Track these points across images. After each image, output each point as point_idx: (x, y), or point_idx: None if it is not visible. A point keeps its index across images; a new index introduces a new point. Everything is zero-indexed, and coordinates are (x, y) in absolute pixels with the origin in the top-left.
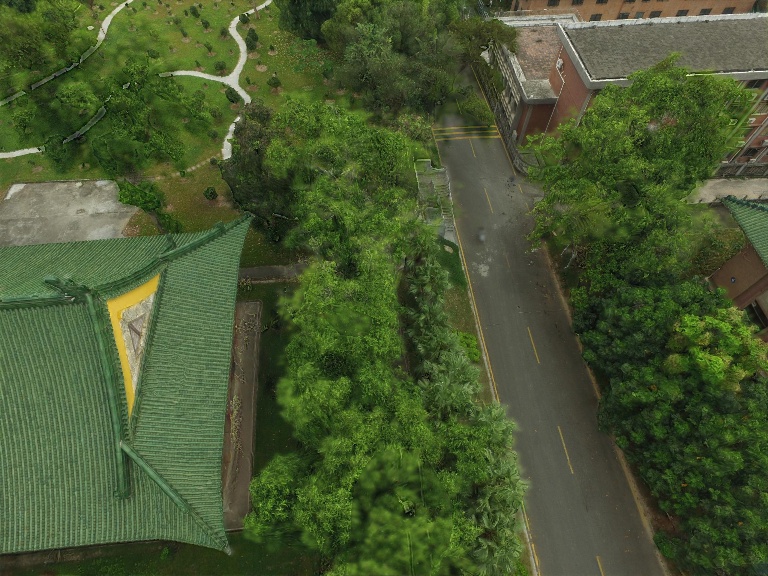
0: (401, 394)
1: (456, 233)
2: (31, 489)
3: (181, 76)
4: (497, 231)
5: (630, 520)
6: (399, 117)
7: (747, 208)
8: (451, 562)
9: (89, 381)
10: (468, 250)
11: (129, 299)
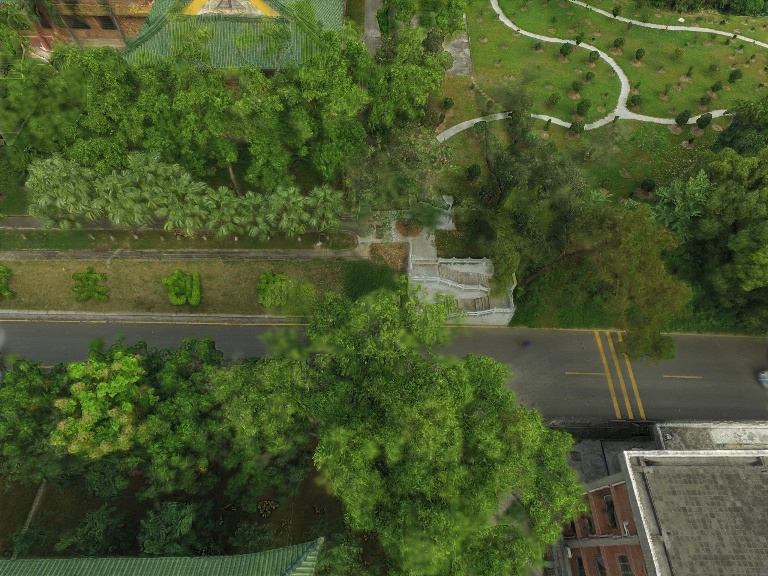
0: (153, 131)
1: None
2: None
3: (617, 79)
4: None
5: None
6: None
7: (285, 568)
8: None
9: None
10: (405, 332)
11: None
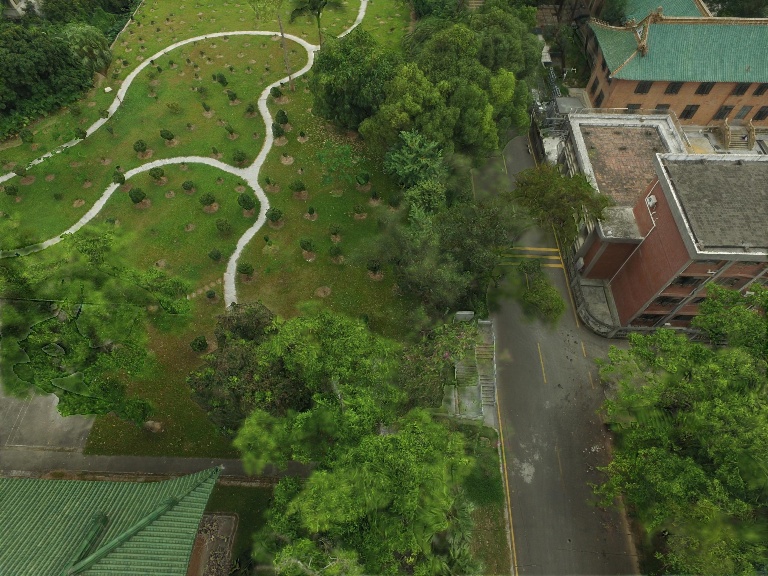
0: None
1: (497, 409)
2: None
3: (194, 164)
4: (549, 413)
5: None
6: (436, 330)
7: None
8: None
9: None
10: (510, 438)
11: None
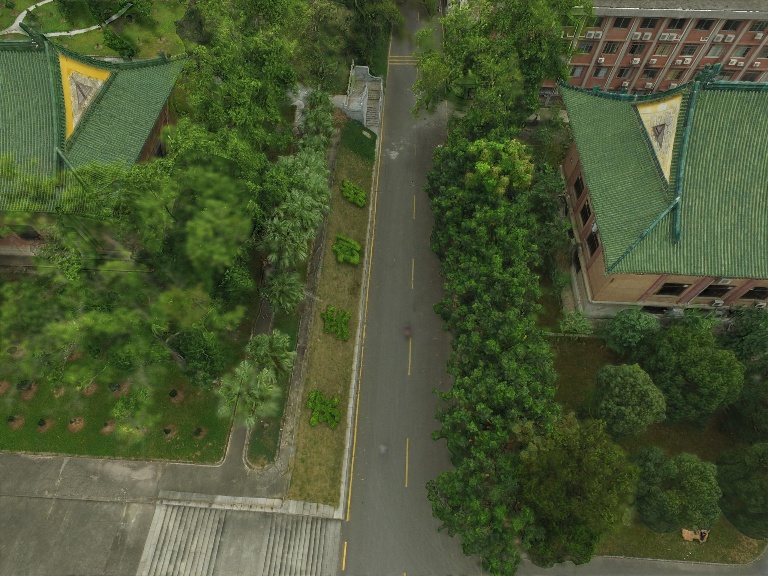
0: None
1: (381, 128)
2: (1, 174)
3: None
4: (415, 130)
5: (445, 321)
6: None
7: (572, 91)
8: (256, 254)
9: (44, 108)
10: (386, 140)
11: (79, 67)
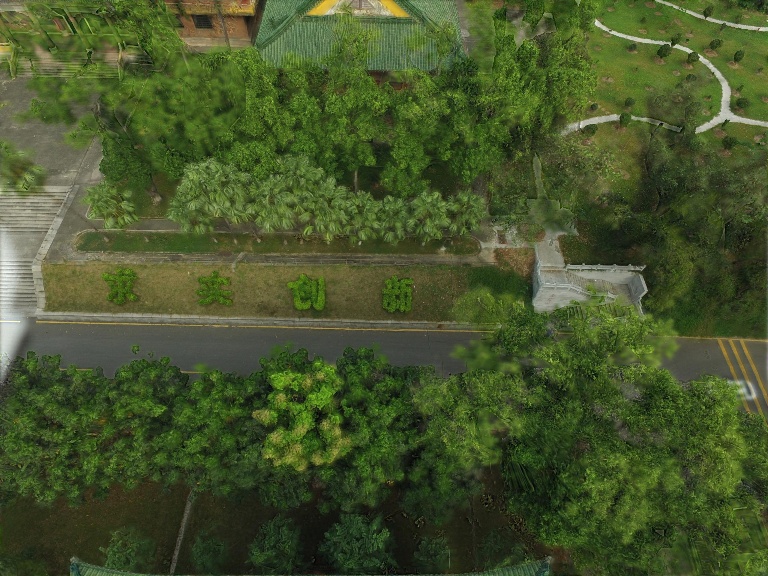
0: (302, 135)
1: None
2: (288, 0)
3: (717, 81)
4: None
5: None
6: None
7: None
8: None
9: None
10: None
11: None
